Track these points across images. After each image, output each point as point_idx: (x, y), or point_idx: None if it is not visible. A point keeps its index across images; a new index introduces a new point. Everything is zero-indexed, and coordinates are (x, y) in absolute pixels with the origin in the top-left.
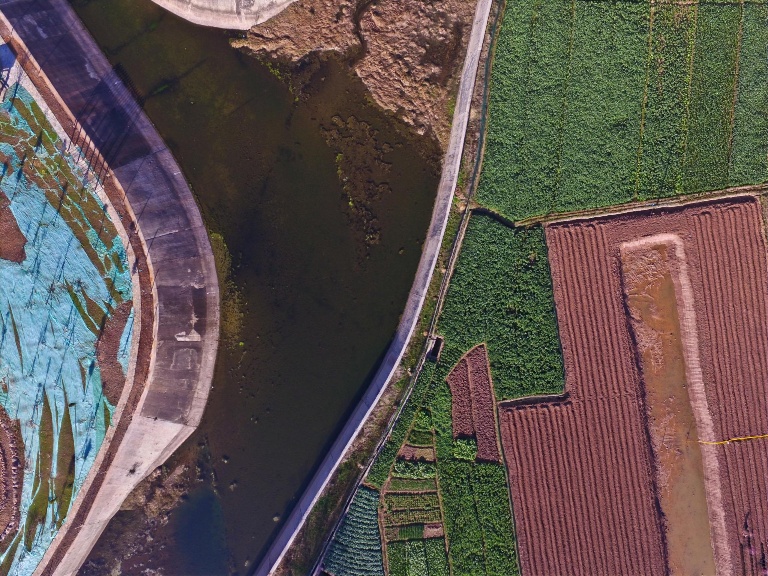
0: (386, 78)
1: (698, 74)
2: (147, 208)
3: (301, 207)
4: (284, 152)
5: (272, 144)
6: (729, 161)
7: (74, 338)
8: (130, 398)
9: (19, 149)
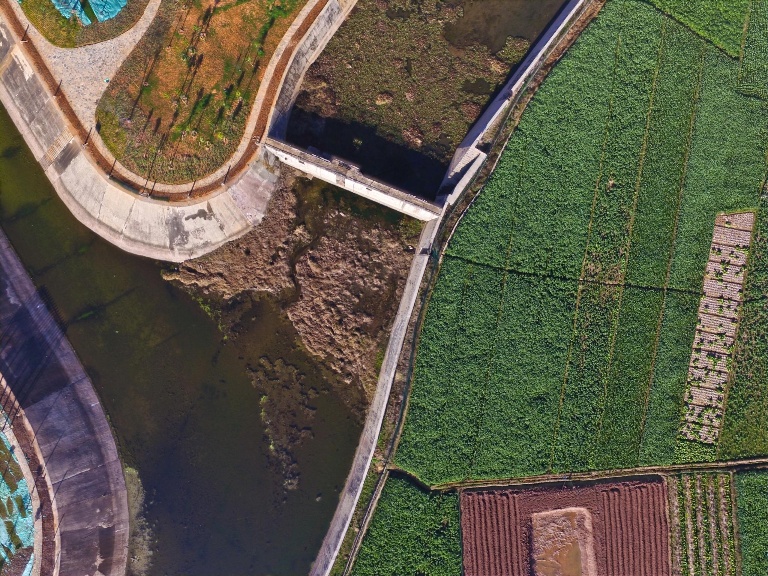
0: (317, 324)
1: (618, 355)
2: (58, 448)
3: (221, 446)
4: (208, 389)
5: (196, 380)
6: (640, 442)
7: None
8: None
9: None
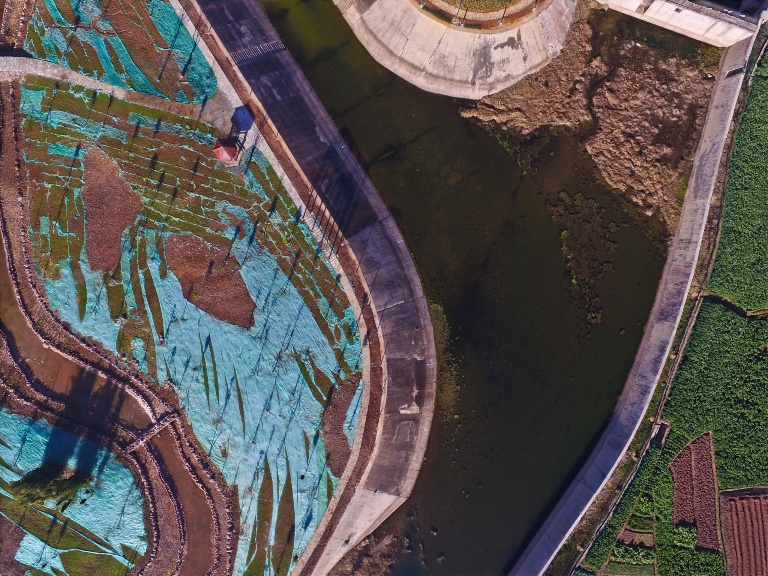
0: (617, 156)
1: None
2: (378, 279)
3: (523, 282)
4: (508, 225)
5: (497, 216)
6: None
7: (300, 407)
8: (354, 470)
9: (252, 213)
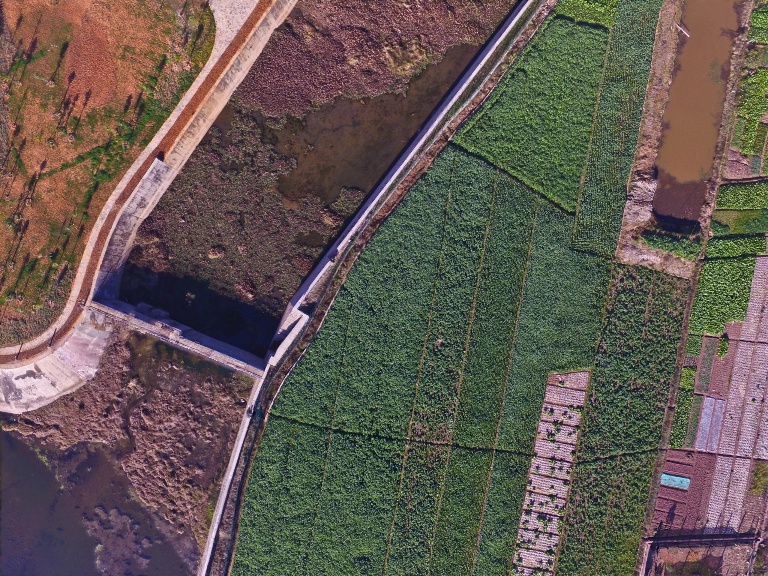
0: (150, 476)
1: (444, 516)
2: None
3: None
4: (46, 536)
5: (35, 528)
6: None
7: None
8: None
9: None
